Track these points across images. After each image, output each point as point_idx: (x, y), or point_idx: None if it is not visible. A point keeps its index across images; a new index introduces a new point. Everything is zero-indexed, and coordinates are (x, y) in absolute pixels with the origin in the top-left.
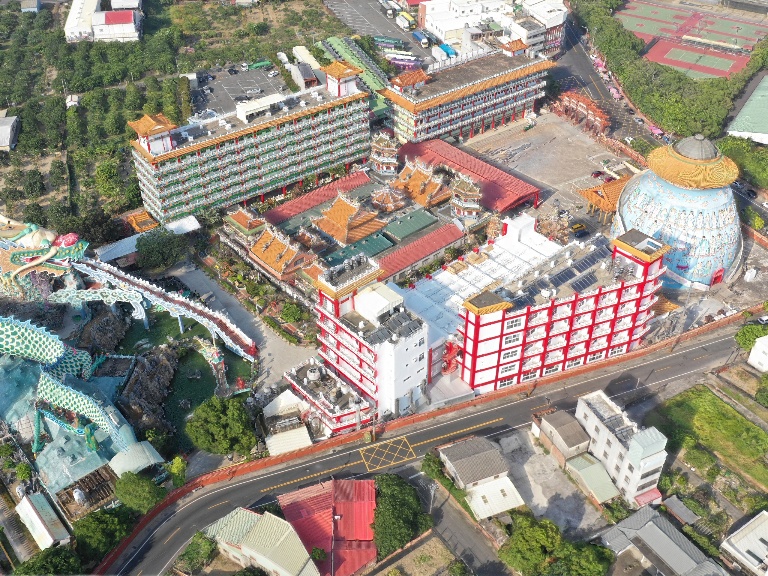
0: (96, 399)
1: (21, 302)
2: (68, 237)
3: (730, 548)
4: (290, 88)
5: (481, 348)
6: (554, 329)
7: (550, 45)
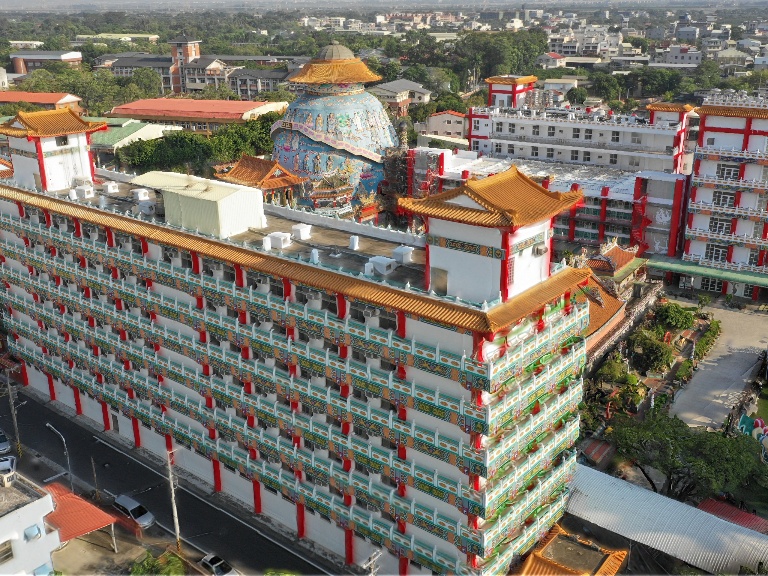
0: None
1: None
2: None
3: None
4: None
5: None
6: None
7: None
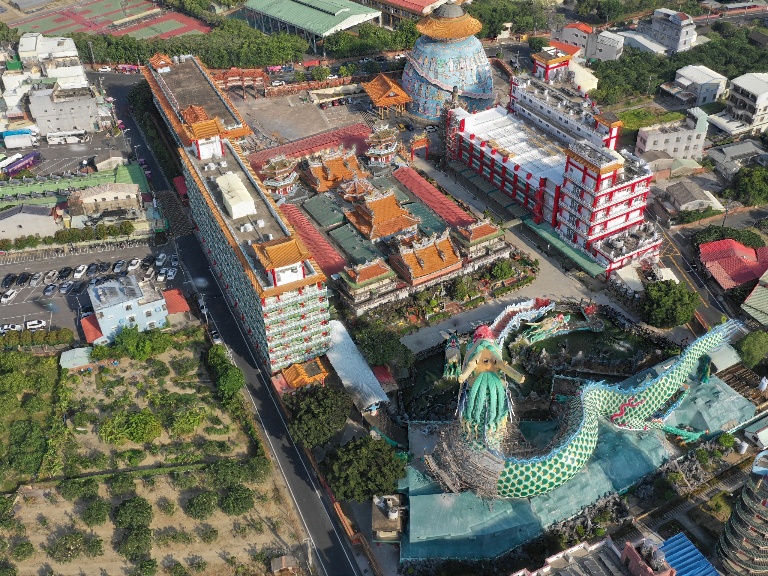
0: (645, 379)
1: None
2: (488, 330)
3: (736, 131)
4: (20, 247)
5: None
6: None
7: None
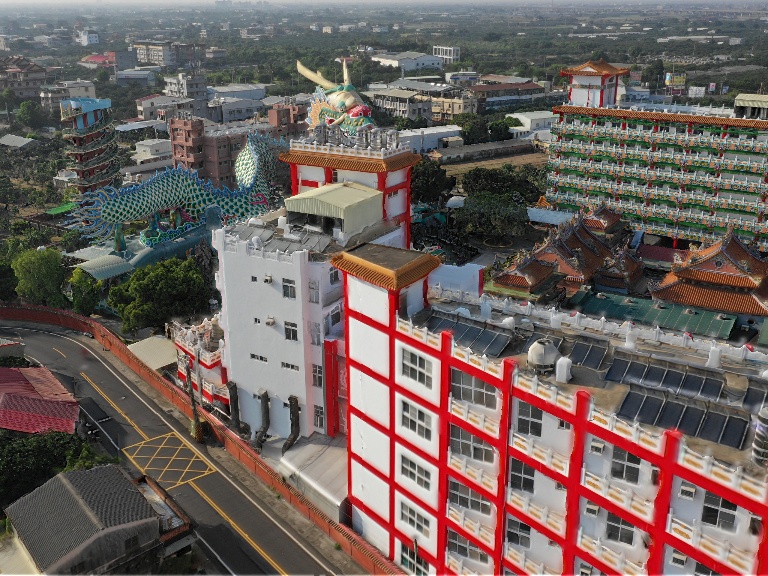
0: None
1: None
2: (358, 107)
3: None
4: None
5: (357, 387)
6: (528, 493)
7: None
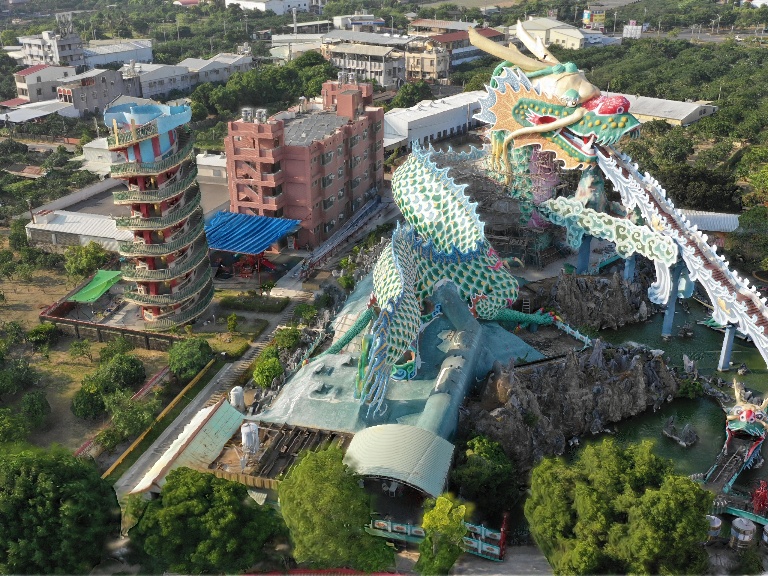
0: (455, 339)
1: (500, 193)
2: None
3: None
4: None
5: None
6: None
7: None
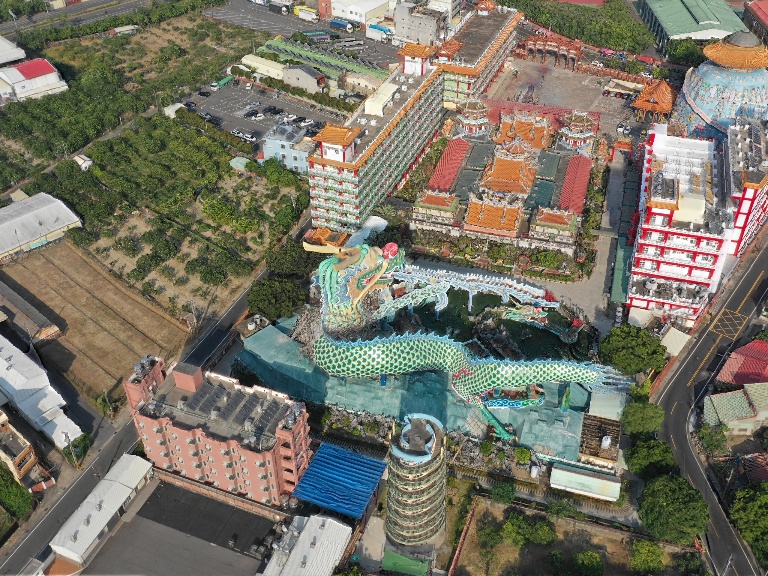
0: None
1: (358, 329)
2: (392, 247)
3: None
4: (292, 92)
5: None
6: None
7: (462, 6)
